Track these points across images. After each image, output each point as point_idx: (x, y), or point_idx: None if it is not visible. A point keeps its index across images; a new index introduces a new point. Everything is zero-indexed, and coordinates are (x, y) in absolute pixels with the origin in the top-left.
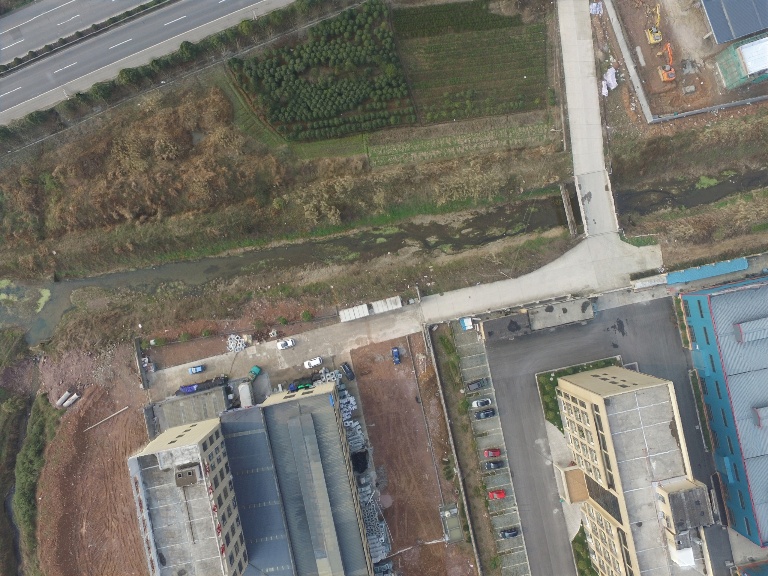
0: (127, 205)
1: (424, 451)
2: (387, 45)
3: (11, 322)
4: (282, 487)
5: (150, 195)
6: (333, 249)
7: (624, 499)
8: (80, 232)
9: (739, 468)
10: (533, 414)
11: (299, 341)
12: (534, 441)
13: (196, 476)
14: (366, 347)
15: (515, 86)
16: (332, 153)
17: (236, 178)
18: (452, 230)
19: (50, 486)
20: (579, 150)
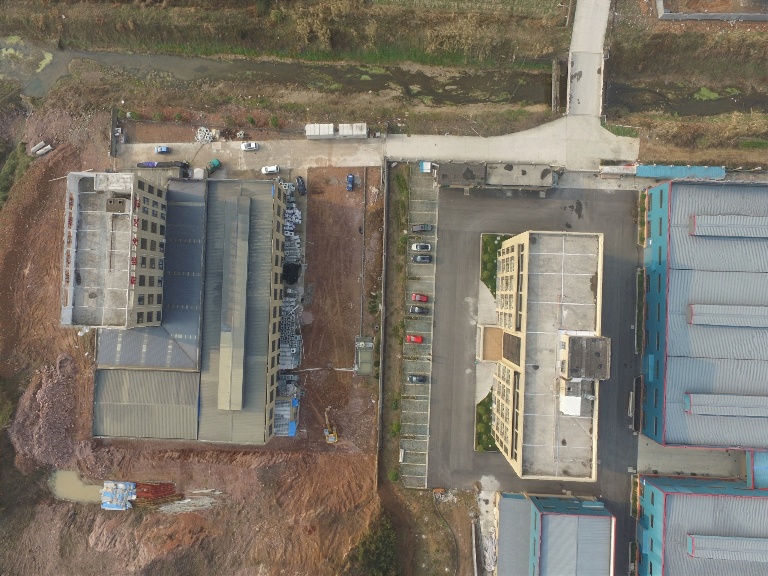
0: None
1: (355, 281)
2: None
3: (12, 75)
4: (208, 260)
5: None
6: (318, 76)
7: (525, 336)
8: (90, 3)
9: (661, 363)
10: (469, 272)
11: (263, 147)
12: (464, 298)
13: (125, 206)
14: (324, 168)
15: None
16: None
17: None
18: (437, 83)
19: (7, 220)
20: (580, 28)
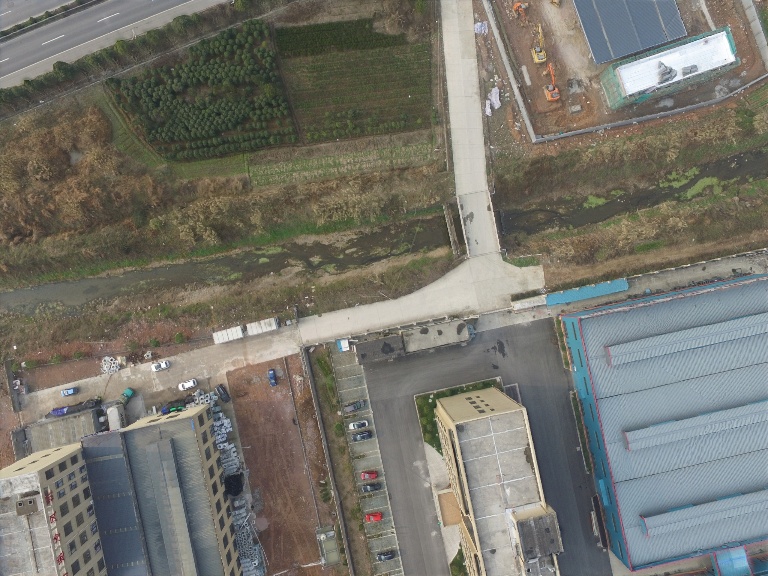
0: (0, 226)
1: (301, 473)
2: (267, 65)
3: None
4: (142, 512)
5: (23, 216)
6: (215, 269)
7: (475, 526)
8: None
9: (611, 491)
10: (412, 436)
11: (174, 363)
12: (412, 463)
13: (37, 505)
14: (243, 369)
15: (397, 106)
16: (213, 173)
17: (111, 199)
18: (336, 250)
19: None
20: (461, 170)
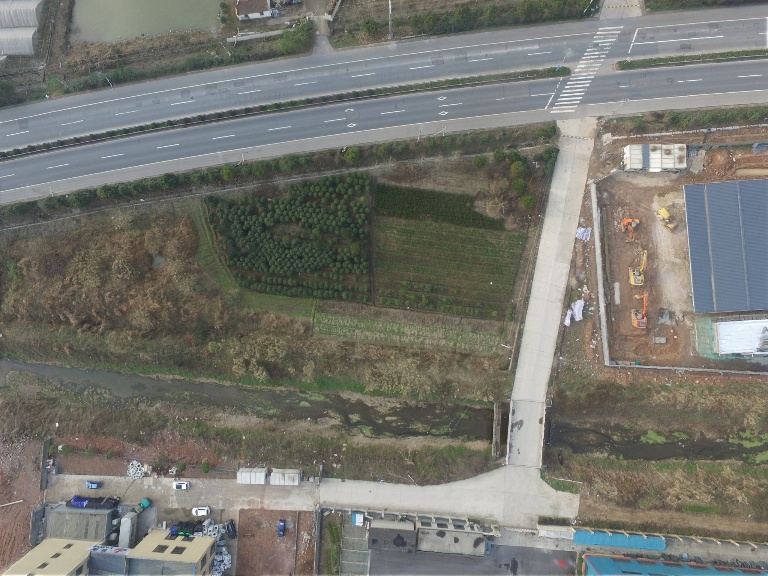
0: (75, 311)
1: None
2: (359, 221)
3: None
4: None
5: (97, 309)
6: (257, 400)
7: None
8: (28, 323)
9: None
10: None
11: (195, 485)
12: None
13: None
14: (256, 510)
15: (476, 293)
16: (279, 309)
17: (179, 314)
18: (377, 414)
19: None
20: (523, 374)
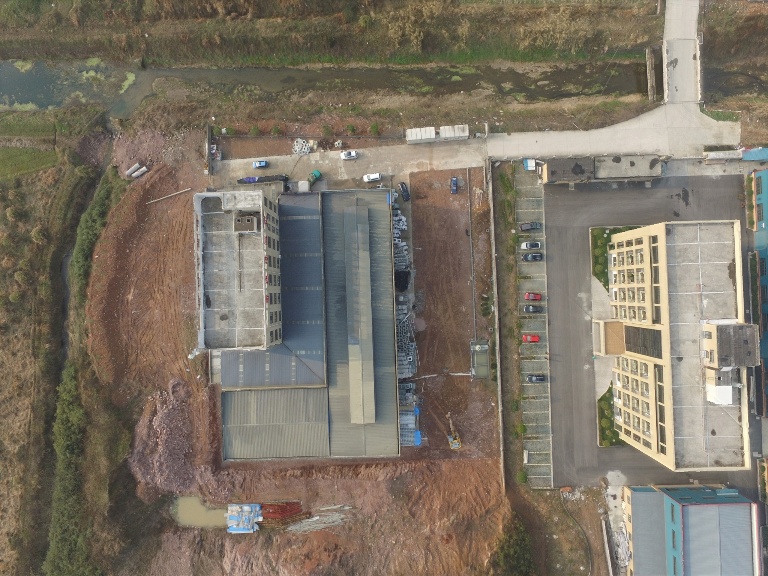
0: None
1: (465, 284)
2: None
3: (95, 98)
4: (327, 273)
5: None
6: (408, 79)
7: (669, 328)
8: (173, 20)
9: None
10: (580, 267)
11: (362, 155)
12: (577, 294)
13: (254, 224)
14: (426, 172)
15: None
16: None
17: None
18: (528, 80)
19: (108, 246)
20: (672, 15)
